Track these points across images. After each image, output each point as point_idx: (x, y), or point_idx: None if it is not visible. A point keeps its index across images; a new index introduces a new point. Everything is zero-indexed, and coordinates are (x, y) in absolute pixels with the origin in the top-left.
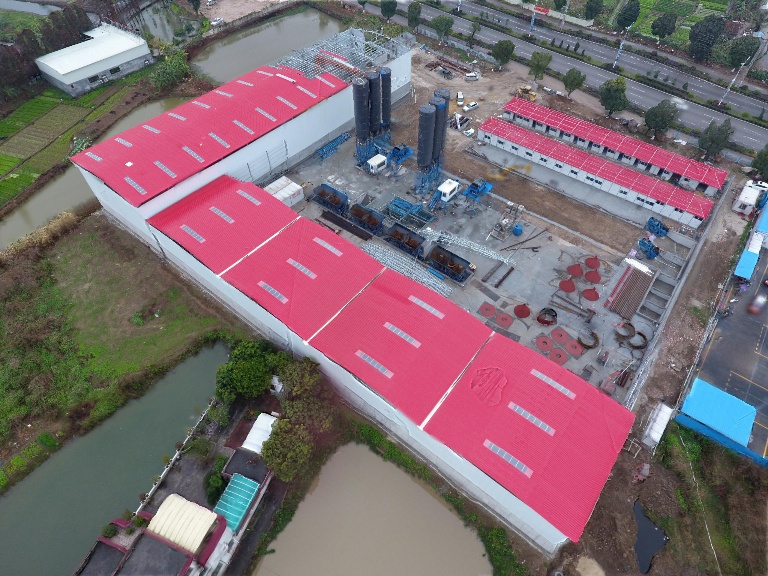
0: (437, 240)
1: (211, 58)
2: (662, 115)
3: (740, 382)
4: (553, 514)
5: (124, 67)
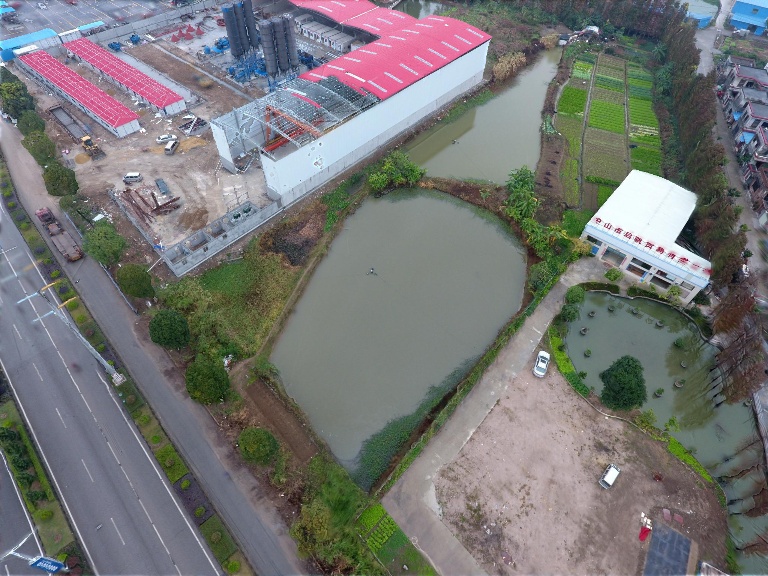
0: None
1: None
2: None
3: None
4: None
5: None
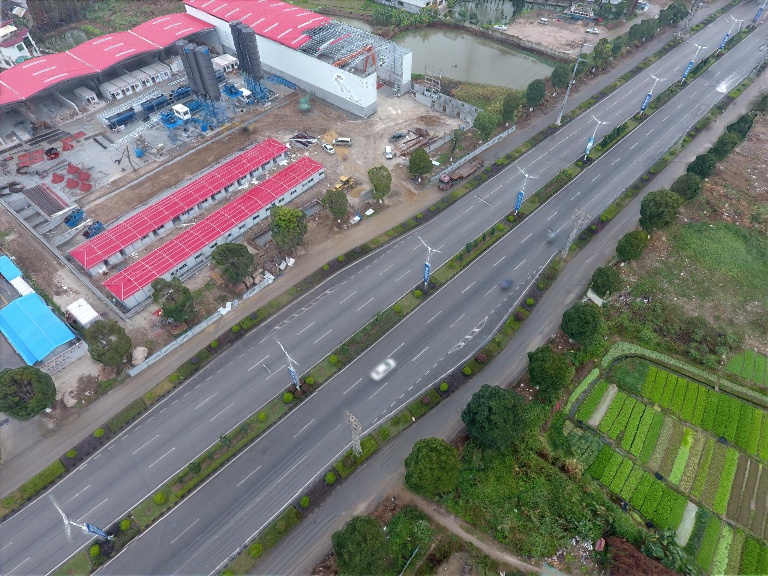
0: None
1: (459, 42)
2: None
3: None
4: None
5: (406, 5)
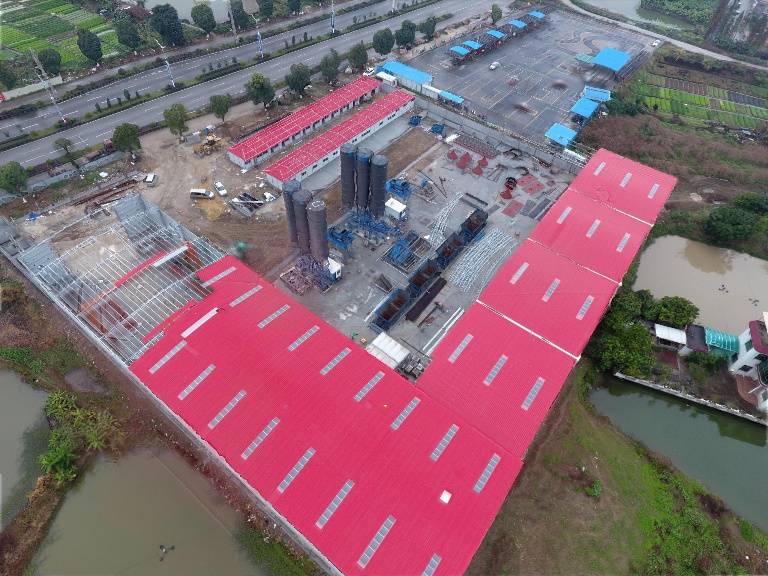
0: (442, 232)
1: None
2: (305, 75)
3: (530, 128)
4: (671, 182)
5: None
